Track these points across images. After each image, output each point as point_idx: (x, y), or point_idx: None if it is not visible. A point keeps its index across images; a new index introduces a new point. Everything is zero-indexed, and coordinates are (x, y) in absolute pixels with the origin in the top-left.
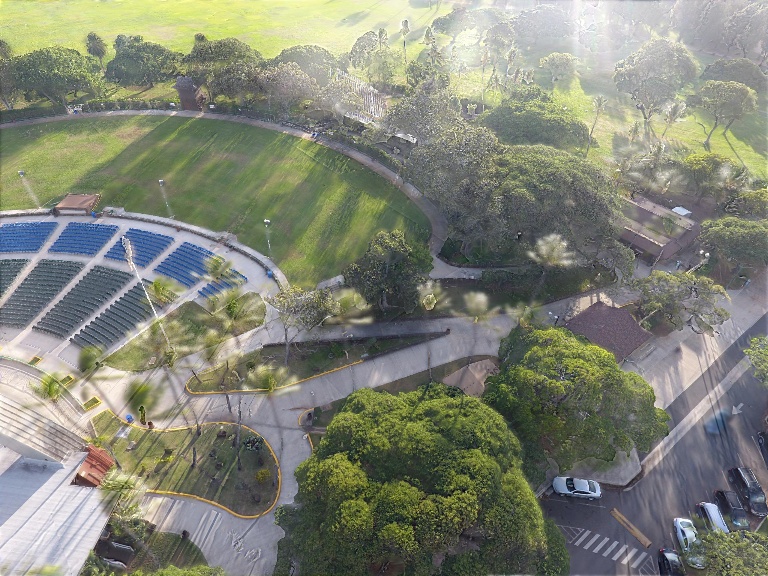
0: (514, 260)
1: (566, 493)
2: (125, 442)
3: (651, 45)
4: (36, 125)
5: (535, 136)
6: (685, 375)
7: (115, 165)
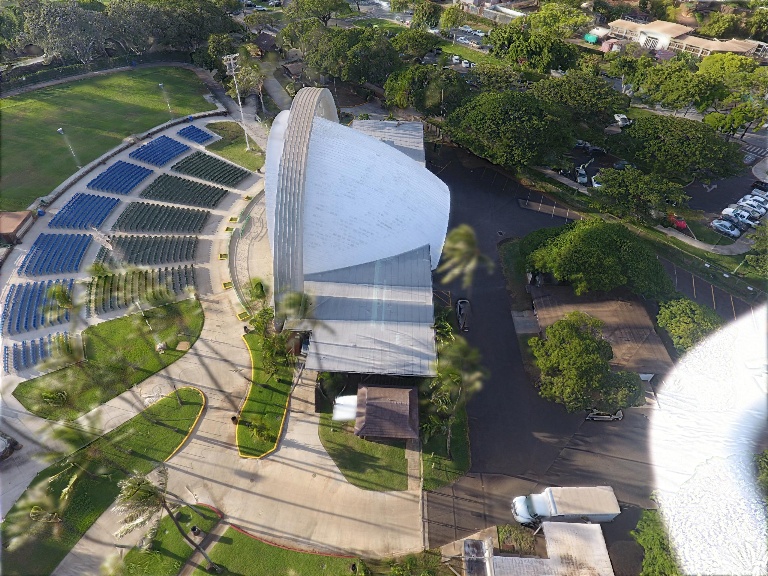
0: None
1: None
2: None
3: None
4: None
5: None
6: None
7: None
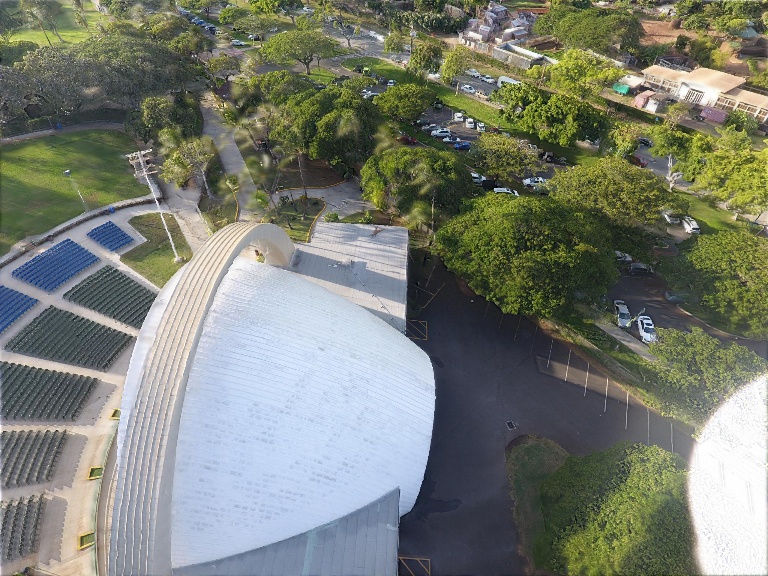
0: None
1: None
2: None
3: None
4: None
5: None
6: None
7: None
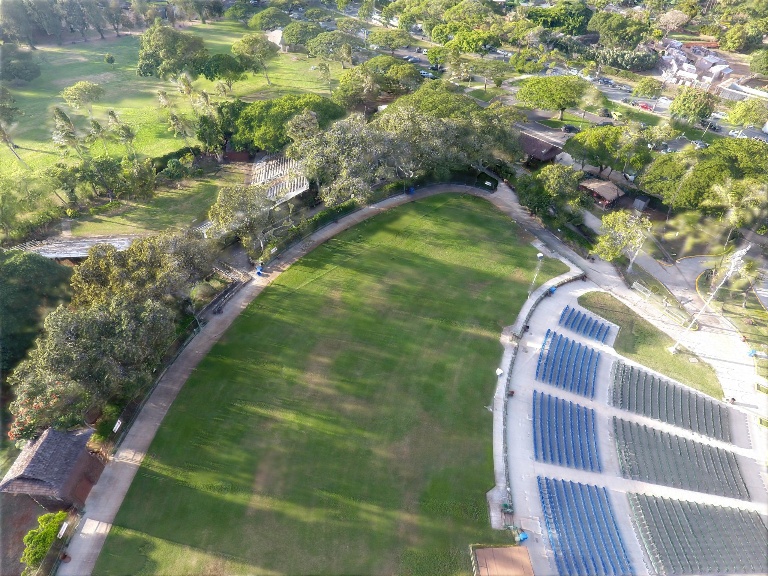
0: None
1: None
2: (767, 351)
3: (162, 35)
4: None
5: (337, 115)
6: None
7: (361, 570)
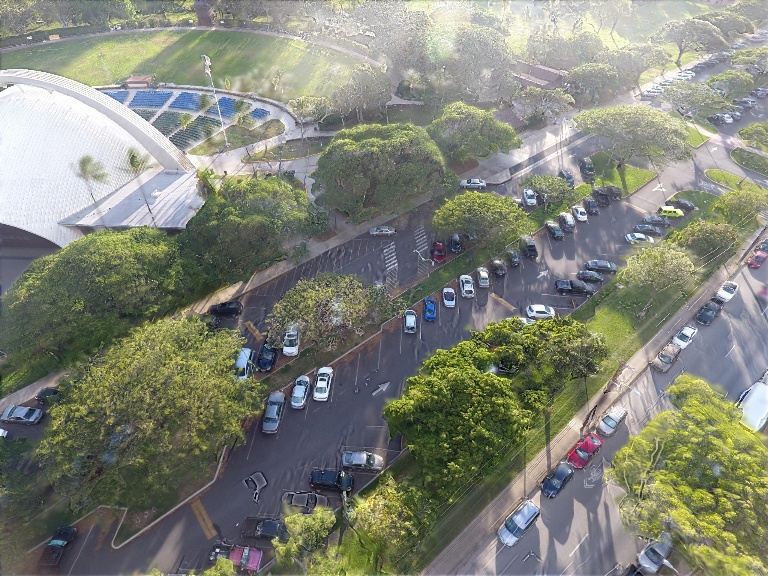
0: (446, 98)
1: (467, 185)
2: None
3: None
4: (89, 38)
5: None
6: (546, 144)
7: (159, 59)
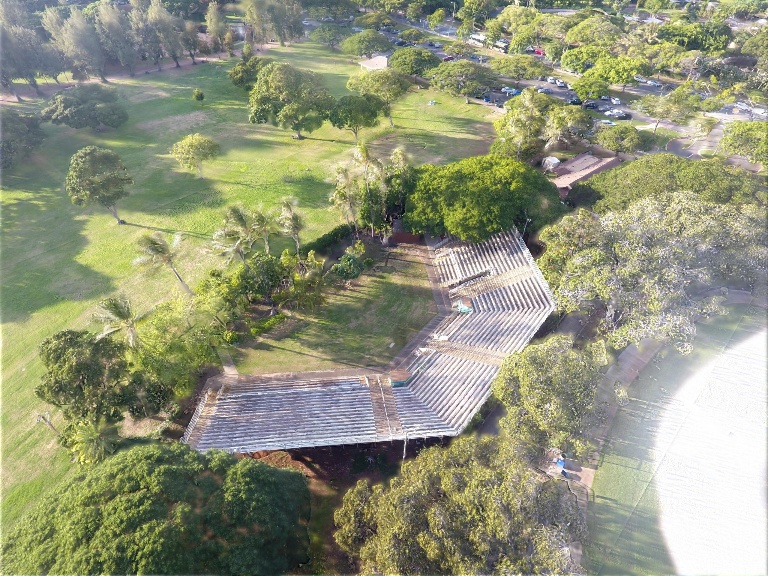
0: None
1: None
2: None
3: (283, 75)
4: None
5: (546, 188)
6: None
7: None
